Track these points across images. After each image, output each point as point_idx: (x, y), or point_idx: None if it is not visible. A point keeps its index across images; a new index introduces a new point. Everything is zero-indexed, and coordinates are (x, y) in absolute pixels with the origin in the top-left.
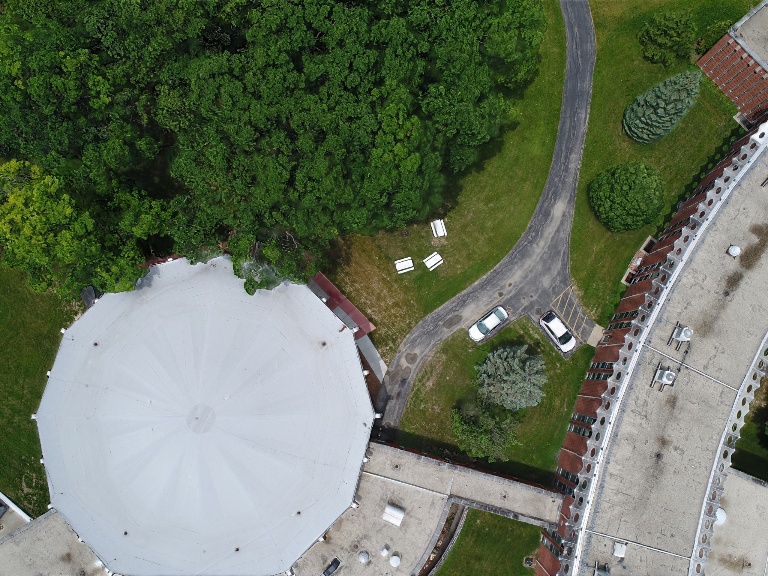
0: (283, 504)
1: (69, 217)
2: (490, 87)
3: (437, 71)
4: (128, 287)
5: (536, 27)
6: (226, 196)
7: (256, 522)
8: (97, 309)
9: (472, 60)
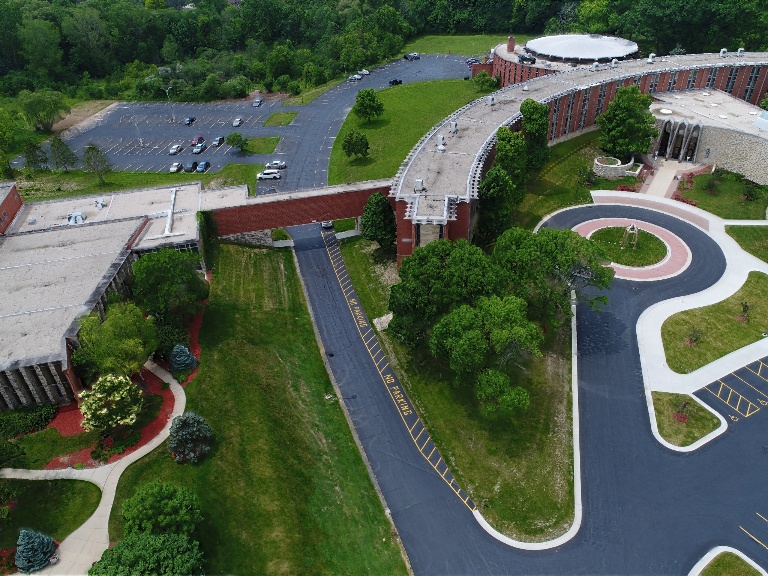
0: (578, 56)
1: (603, 5)
2: (737, 23)
3: (723, 4)
4: (595, 28)
5: (766, 21)
6: (644, 2)
7: (567, 55)
8: (579, 36)
9: (735, 6)
